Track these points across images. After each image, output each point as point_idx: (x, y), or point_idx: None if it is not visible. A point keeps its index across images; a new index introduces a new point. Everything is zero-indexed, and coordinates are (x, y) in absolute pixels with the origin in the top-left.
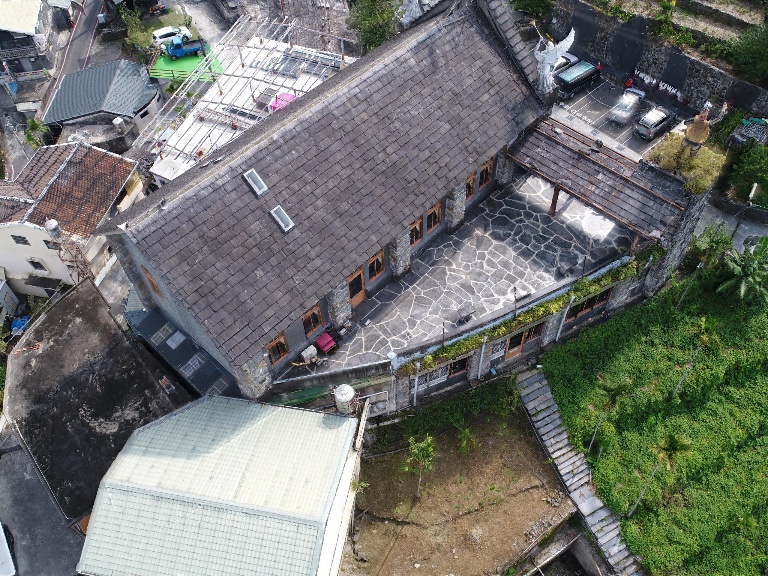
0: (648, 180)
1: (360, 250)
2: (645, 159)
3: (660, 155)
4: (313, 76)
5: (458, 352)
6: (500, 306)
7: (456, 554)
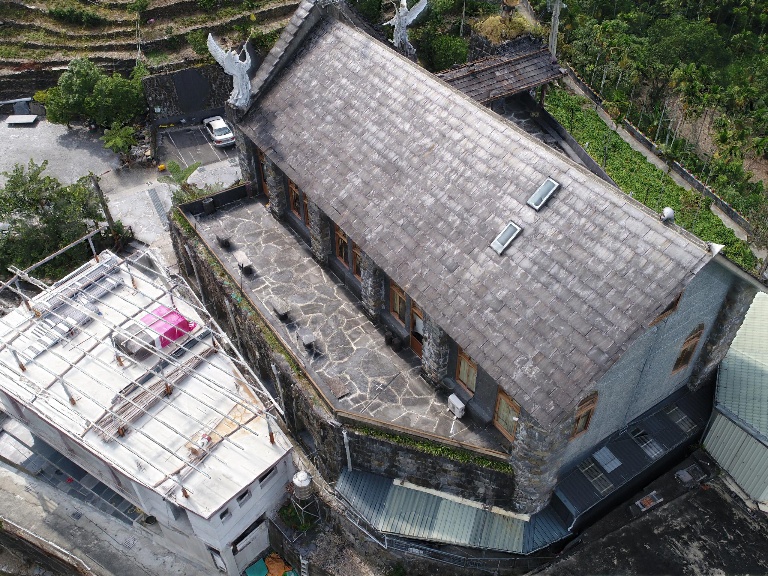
0: (516, 52)
1: None
2: (498, 44)
3: (504, 32)
4: (108, 297)
5: None
6: None
7: None
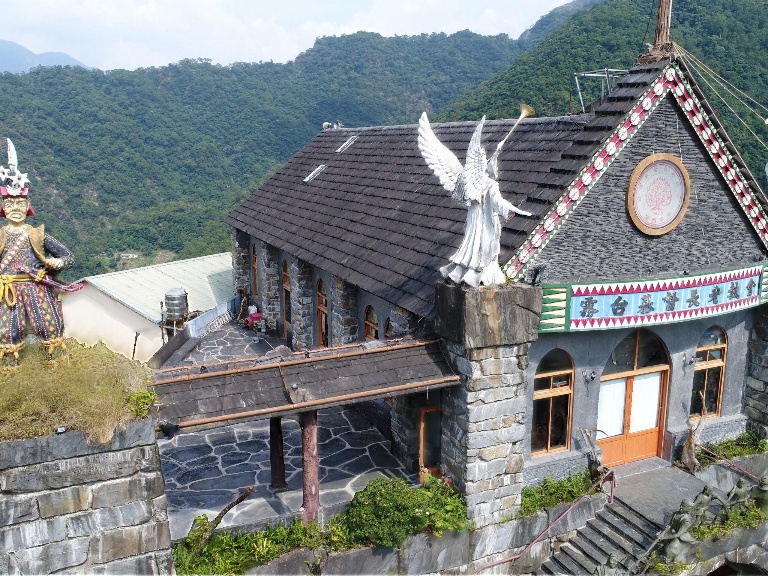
0: None
1: None
2: None
3: None
4: None
5: None
6: None
7: None
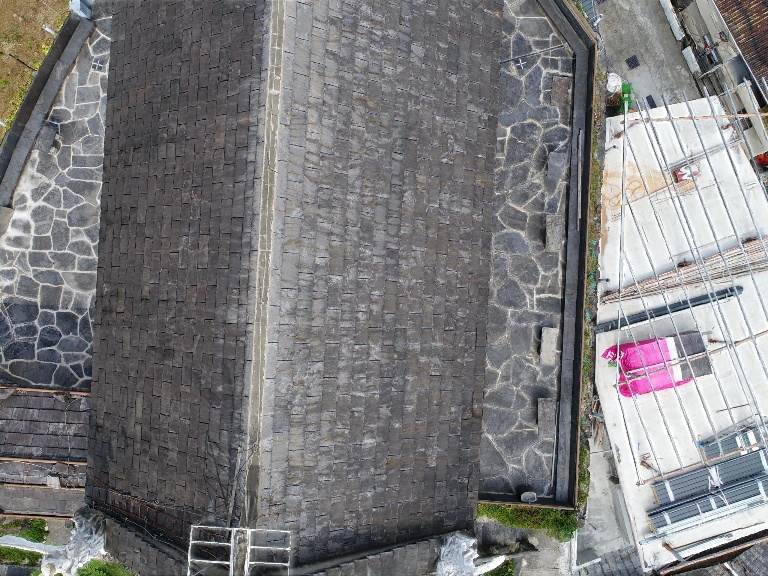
0: None
1: (124, 4)
2: None
3: None
4: None
5: (25, 86)
6: (27, 191)
7: (17, 18)
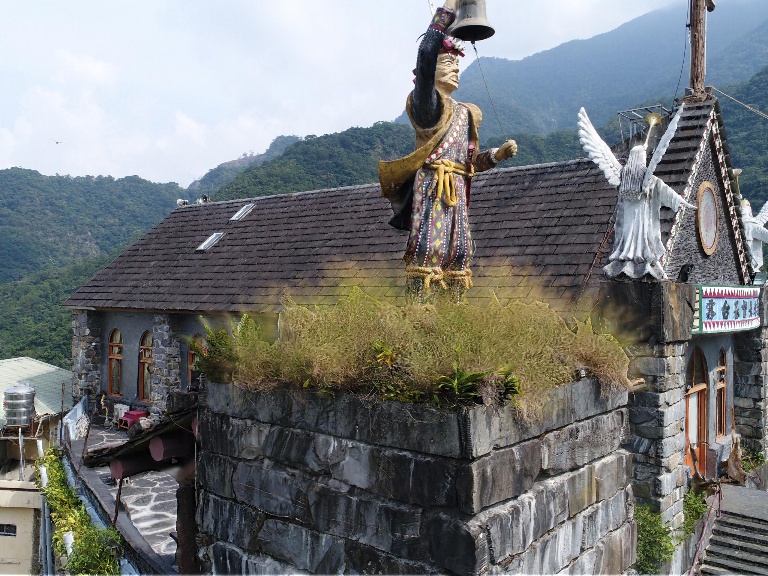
0: None
1: None
2: None
3: None
4: None
5: None
6: None
7: None
